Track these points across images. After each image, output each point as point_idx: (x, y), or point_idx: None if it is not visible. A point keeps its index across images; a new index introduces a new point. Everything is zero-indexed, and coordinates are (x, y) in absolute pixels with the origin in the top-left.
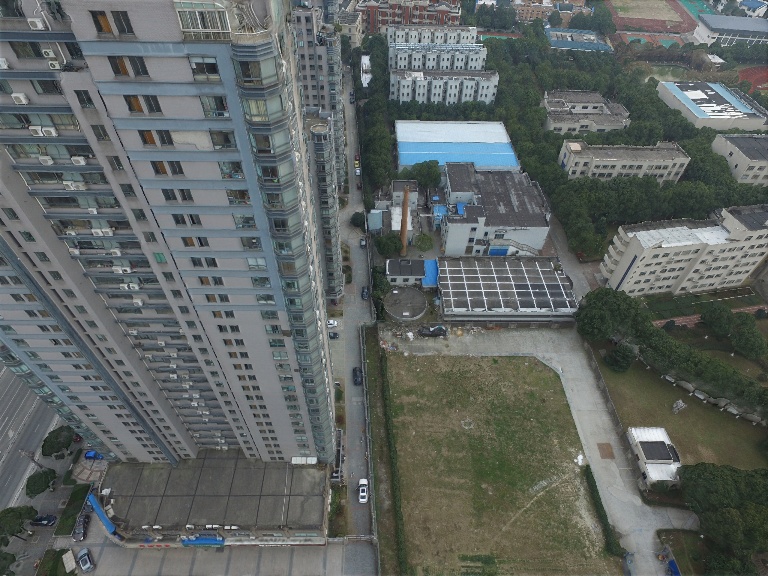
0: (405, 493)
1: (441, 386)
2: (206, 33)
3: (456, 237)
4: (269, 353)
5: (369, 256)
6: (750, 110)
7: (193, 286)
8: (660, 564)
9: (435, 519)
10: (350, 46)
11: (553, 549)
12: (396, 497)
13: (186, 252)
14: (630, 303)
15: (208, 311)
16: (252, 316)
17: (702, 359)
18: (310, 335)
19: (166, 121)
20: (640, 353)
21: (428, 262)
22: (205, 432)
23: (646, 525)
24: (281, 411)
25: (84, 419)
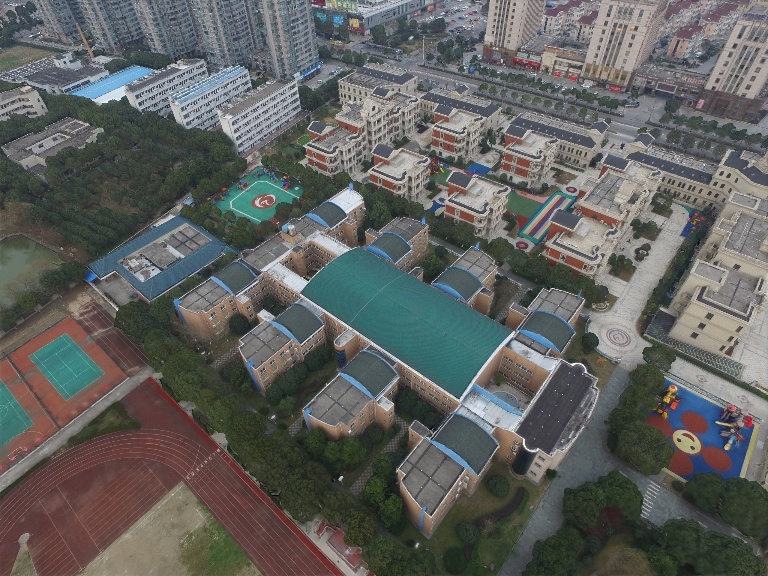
0: None
1: None
2: None
3: None
4: None
5: None
6: None
7: None
8: None
9: None
10: (332, 93)
11: None
12: None
13: None
14: None
15: None
16: None
17: None
18: None
19: None
20: None
21: None
22: None
23: None
24: None
25: None
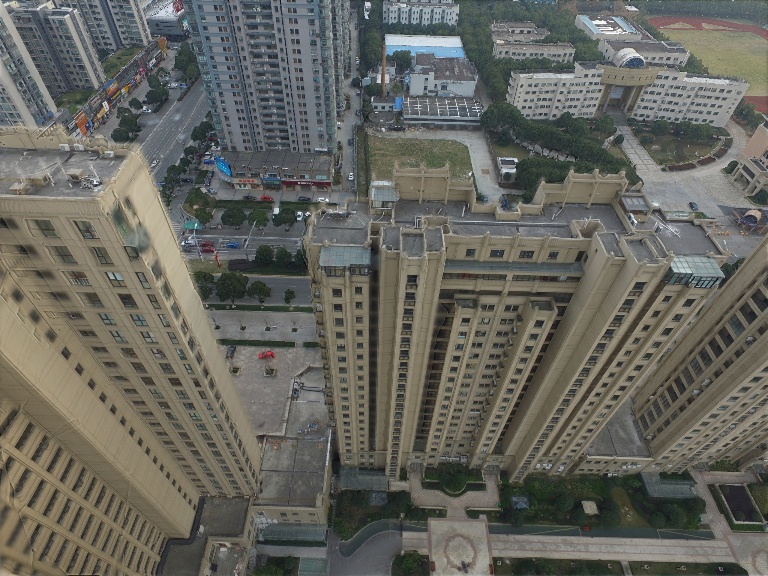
0: None
1: (398, 148)
2: None
3: (416, 85)
4: (310, 50)
5: (362, 98)
6: (634, 31)
7: (284, 2)
8: (500, 203)
9: None
10: None
11: None
12: (368, 176)
13: None
14: (510, 106)
15: (288, 19)
16: (305, 23)
17: (542, 126)
18: (327, 36)
19: None
20: (514, 132)
21: (398, 98)
22: (271, 133)
23: (498, 193)
24: (312, 100)
25: (219, 105)
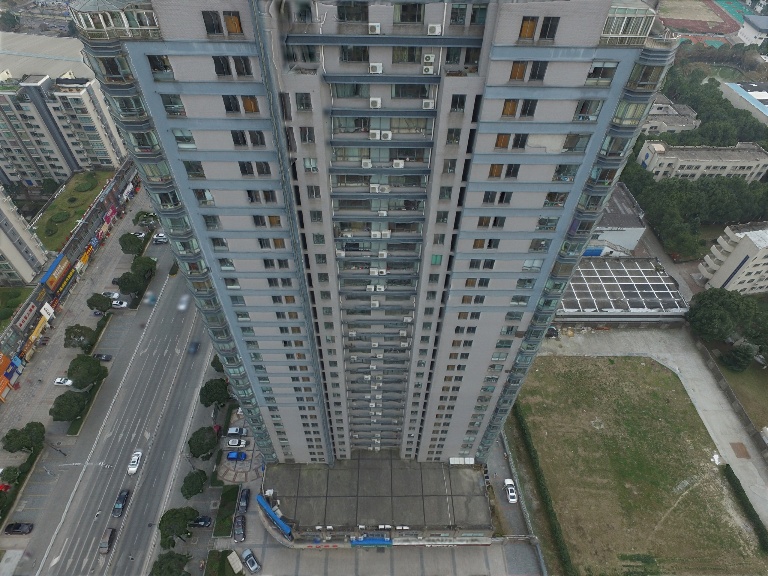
0: (551, 493)
1: (563, 386)
2: (622, 38)
3: None
4: (490, 354)
5: None
6: None
7: (457, 288)
8: None
9: (586, 519)
10: None
11: (709, 548)
12: (547, 497)
13: (470, 254)
14: (748, 303)
15: (456, 312)
16: (496, 317)
17: None
18: (543, 336)
19: (532, 125)
20: (760, 353)
21: None
22: (364, 433)
23: None
24: (466, 412)
25: (267, 420)
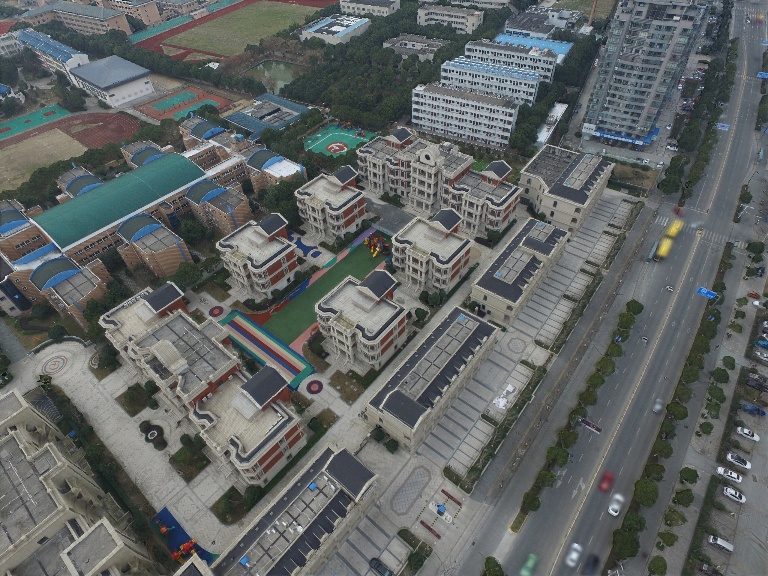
0: None
1: None
2: None
3: None
4: None
5: None
6: (328, 19)
7: None
8: None
9: None
10: None
11: None
12: None
13: None
14: None
15: None
16: None
17: None
18: None
19: None
20: None
21: None
22: None
23: None
24: None
25: None
